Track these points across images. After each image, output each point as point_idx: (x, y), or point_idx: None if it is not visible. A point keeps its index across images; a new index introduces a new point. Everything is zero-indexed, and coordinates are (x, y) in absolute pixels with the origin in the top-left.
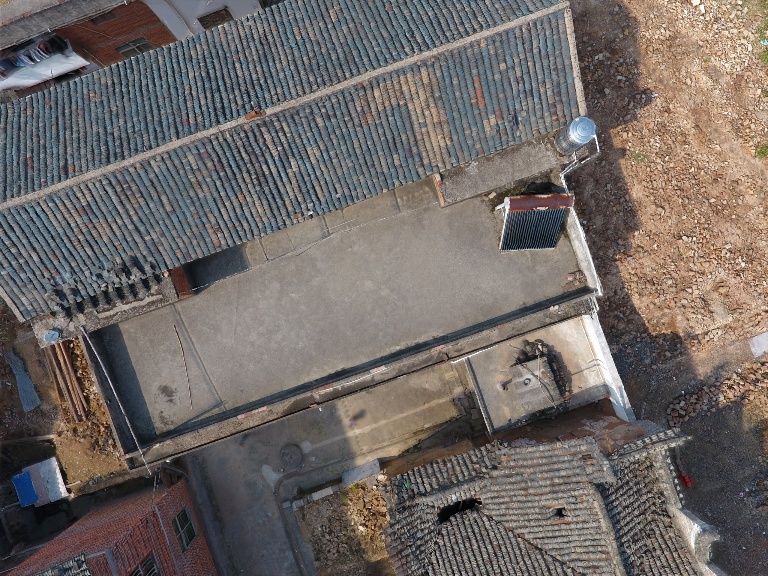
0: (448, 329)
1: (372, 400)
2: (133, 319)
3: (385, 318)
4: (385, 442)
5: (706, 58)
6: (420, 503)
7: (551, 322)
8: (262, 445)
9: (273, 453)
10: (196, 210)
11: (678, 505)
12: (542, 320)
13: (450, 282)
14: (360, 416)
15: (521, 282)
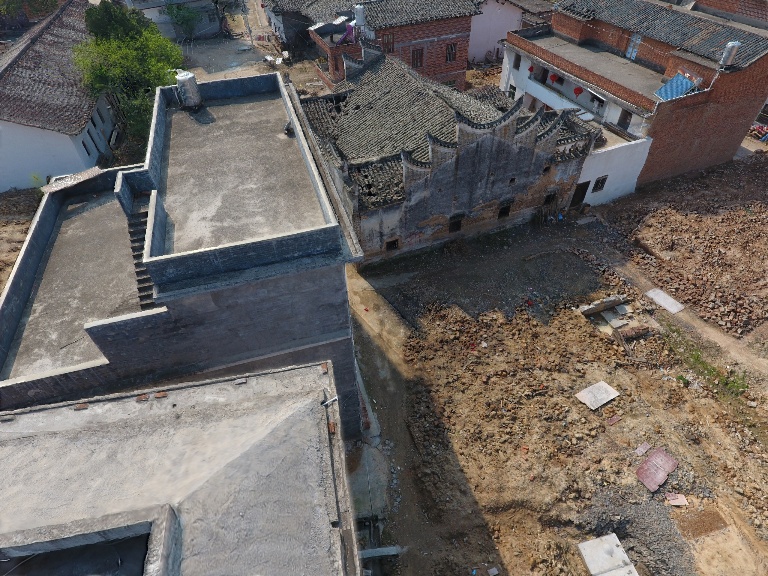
0: None
1: None
2: (558, 38)
3: None
4: None
5: None
6: None
7: None
8: None
9: None
10: None
11: None
12: None
13: None
14: None
15: None
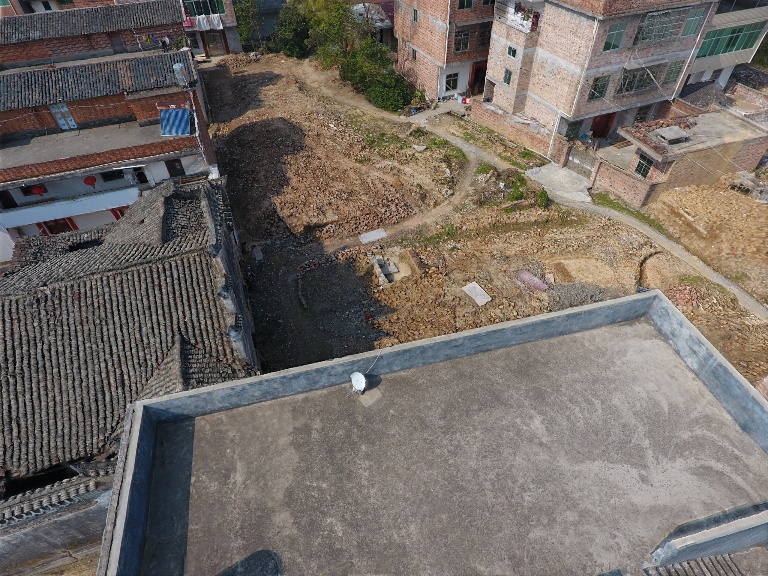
0: None
1: None
2: None
3: None
4: None
5: None
6: (60, 236)
7: None
8: None
9: None
10: (7, 94)
11: None
12: None
13: None
14: None
15: None
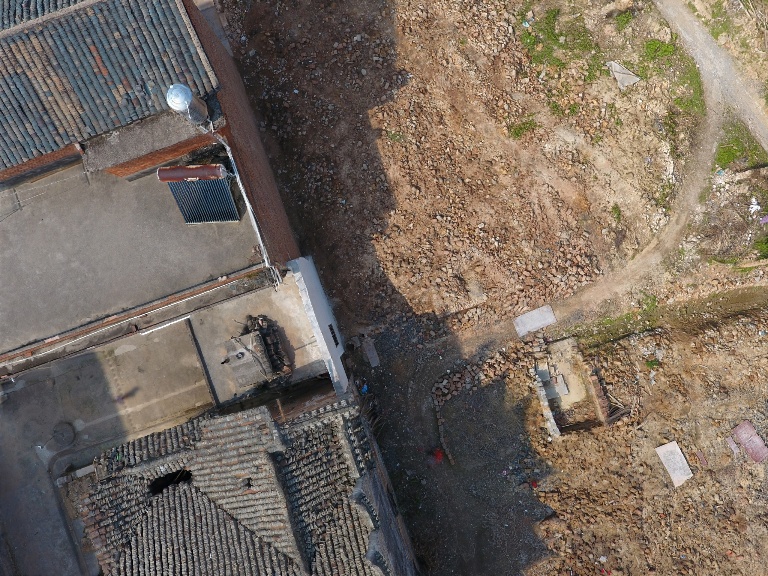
0: (137, 301)
1: (144, 379)
2: None
3: (75, 290)
4: (157, 420)
5: (463, 39)
6: (127, 475)
7: (236, 294)
8: (36, 423)
9: (47, 431)
10: None
11: (356, 475)
12: (229, 292)
13: (138, 255)
14: (132, 395)
15: (208, 255)
